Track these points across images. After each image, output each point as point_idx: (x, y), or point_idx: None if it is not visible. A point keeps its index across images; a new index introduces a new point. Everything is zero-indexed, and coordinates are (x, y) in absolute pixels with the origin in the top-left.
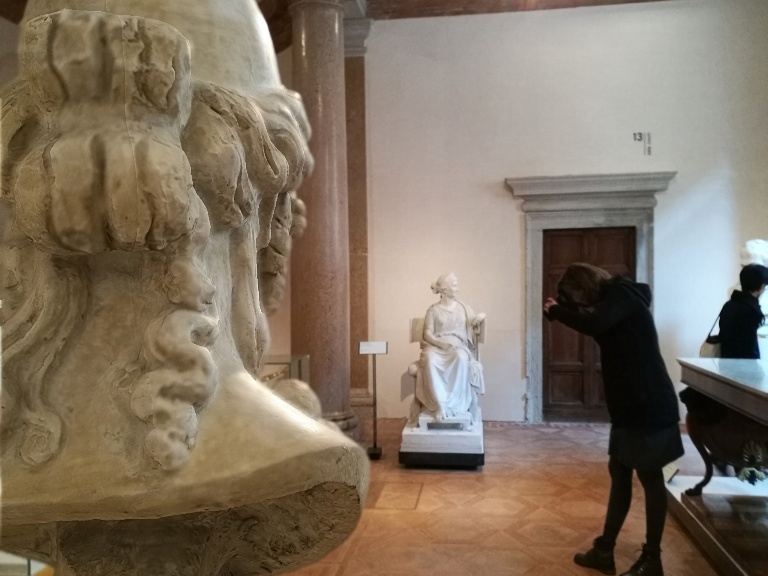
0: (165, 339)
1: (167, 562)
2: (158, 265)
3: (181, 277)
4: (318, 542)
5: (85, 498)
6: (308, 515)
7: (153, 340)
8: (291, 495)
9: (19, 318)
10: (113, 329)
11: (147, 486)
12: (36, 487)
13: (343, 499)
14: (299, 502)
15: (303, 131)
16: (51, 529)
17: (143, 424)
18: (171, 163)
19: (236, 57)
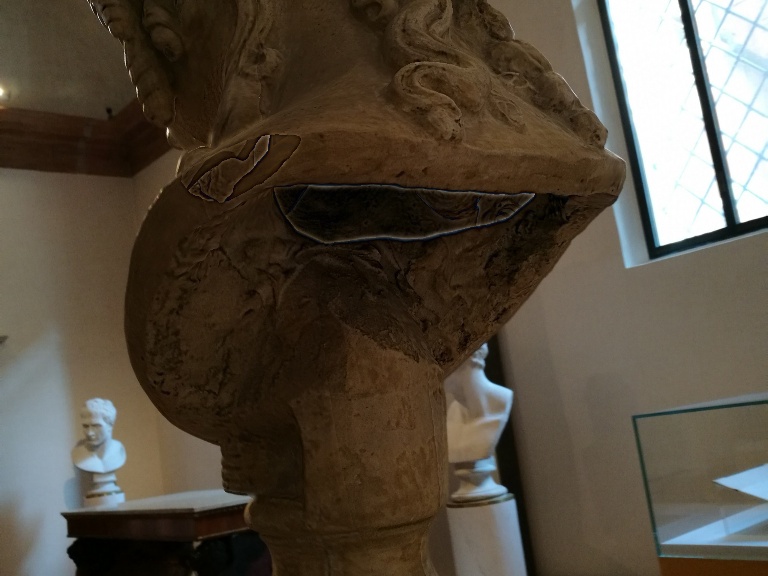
0: (538, 51)
1: (421, 341)
2: (473, 4)
3: (502, 16)
4: (476, 340)
5: (568, 158)
6: (483, 304)
7: (526, 52)
8: (475, 283)
9: (429, 0)
10: (462, 48)
11: (599, 154)
12: (532, 143)
13: (556, 257)
14: (483, 288)
15: None
16: (240, 347)
17: (555, 114)
18: None
19: None
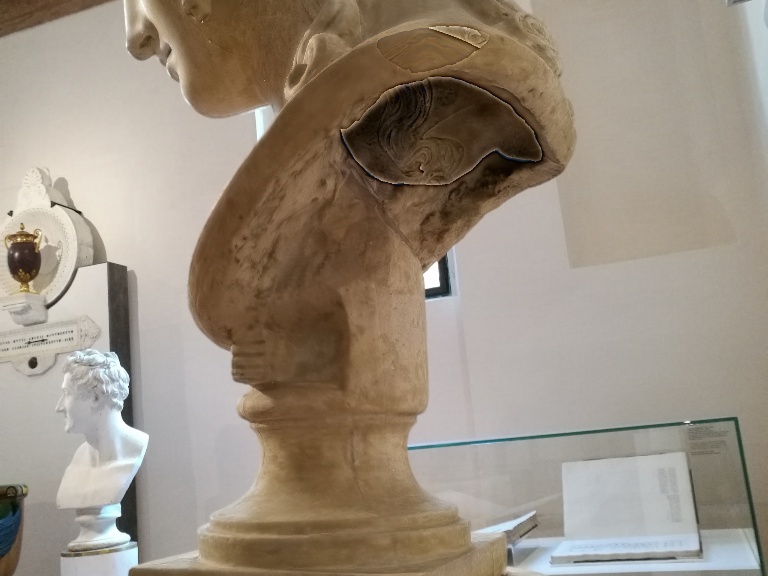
0: None
1: None
2: None
3: None
4: None
5: None
6: None
7: None
8: (412, 235)
9: None
10: None
11: None
12: None
13: None
14: (417, 241)
15: None
16: (288, 235)
17: None
18: None
19: None
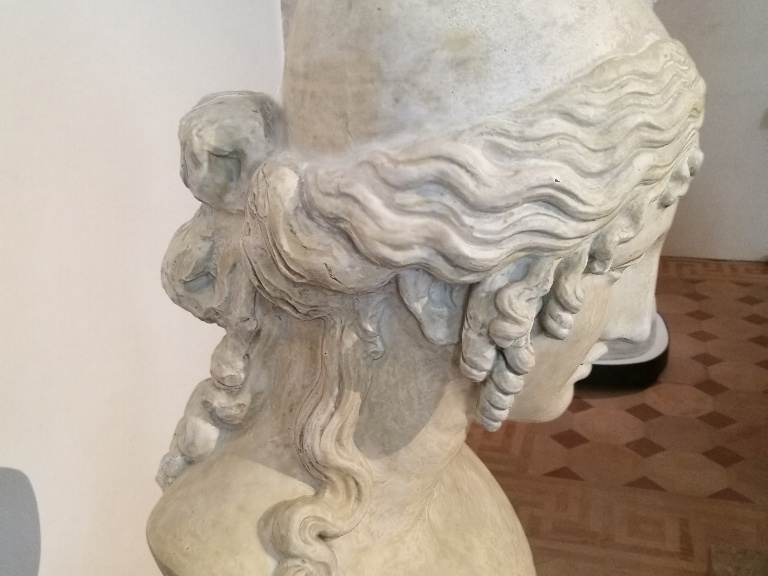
0: None
1: None
2: None
3: None
4: None
5: None
6: None
7: None
8: None
9: None
10: None
11: None
12: None
13: None
14: None
15: (466, 202)
16: None
17: None
18: (168, 258)
19: (326, 115)
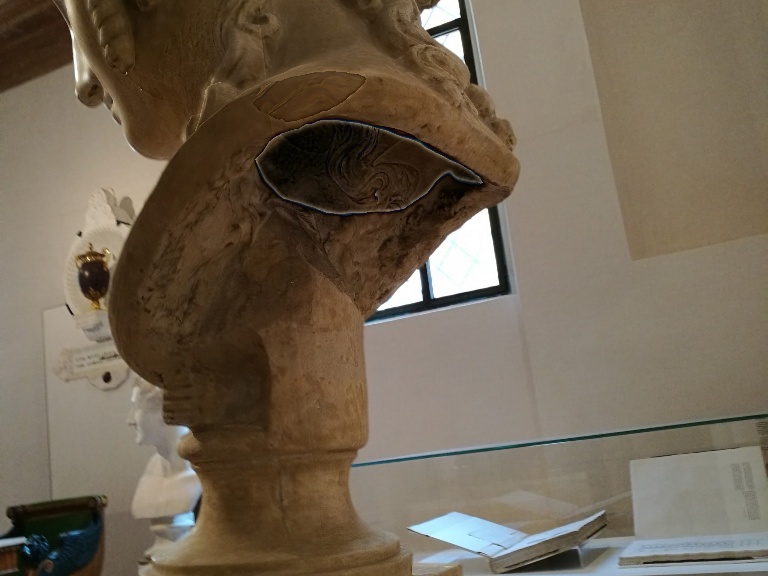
0: None
1: None
2: None
3: None
4: None
5: None
6: (372, 283)
7: None
8: (369, 262)
9: None
10: None
11: None
12: None
13: None
14: (375, 268)
15: None
16: (208, 280)
17: (480, 118)
18: None
19: None
